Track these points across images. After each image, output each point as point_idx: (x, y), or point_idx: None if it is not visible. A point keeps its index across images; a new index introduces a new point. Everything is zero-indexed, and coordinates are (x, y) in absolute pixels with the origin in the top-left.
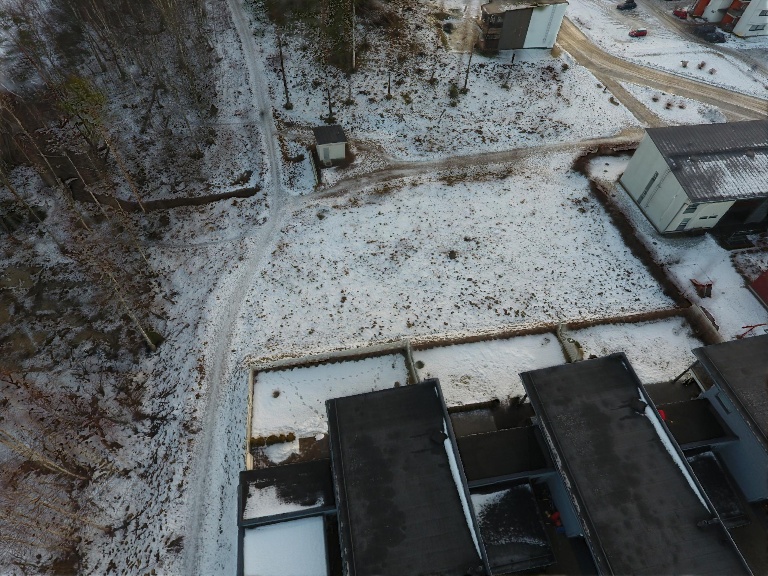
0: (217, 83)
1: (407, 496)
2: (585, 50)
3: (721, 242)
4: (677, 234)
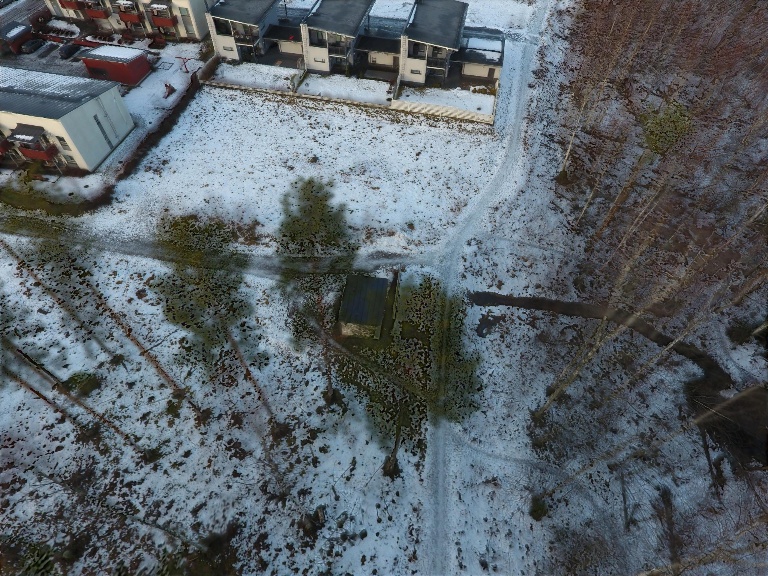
0: None
1: None
2: None
3: None
4: None
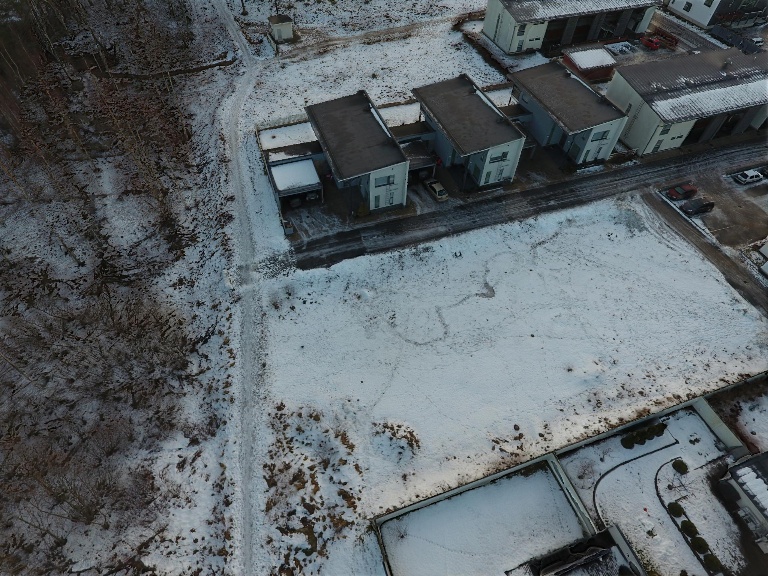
0: (186, 4)
1: (354, 128)
2: None
3: (545, 55)
4: (518, 54)
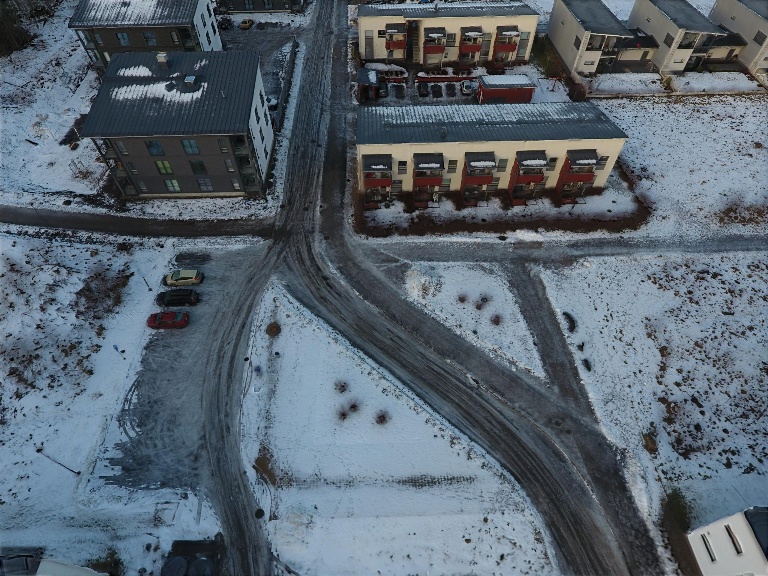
0: None
1: None
2: (592, 530)
3: None
4: None
